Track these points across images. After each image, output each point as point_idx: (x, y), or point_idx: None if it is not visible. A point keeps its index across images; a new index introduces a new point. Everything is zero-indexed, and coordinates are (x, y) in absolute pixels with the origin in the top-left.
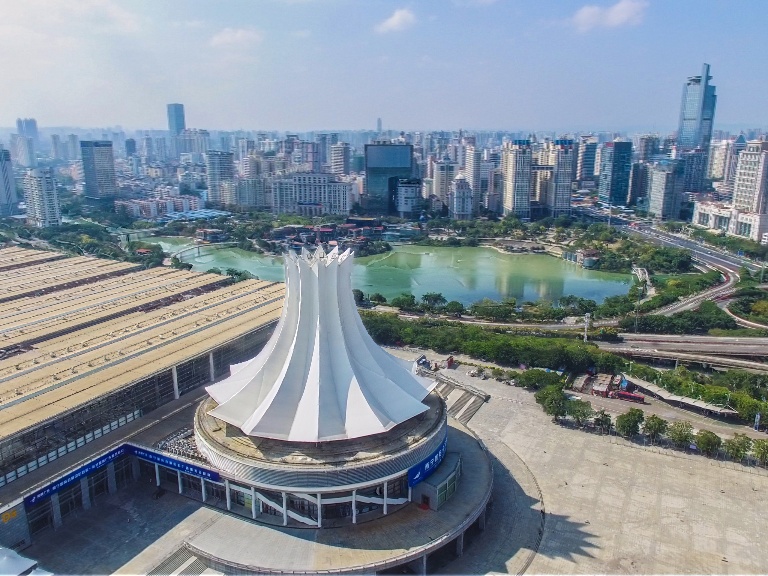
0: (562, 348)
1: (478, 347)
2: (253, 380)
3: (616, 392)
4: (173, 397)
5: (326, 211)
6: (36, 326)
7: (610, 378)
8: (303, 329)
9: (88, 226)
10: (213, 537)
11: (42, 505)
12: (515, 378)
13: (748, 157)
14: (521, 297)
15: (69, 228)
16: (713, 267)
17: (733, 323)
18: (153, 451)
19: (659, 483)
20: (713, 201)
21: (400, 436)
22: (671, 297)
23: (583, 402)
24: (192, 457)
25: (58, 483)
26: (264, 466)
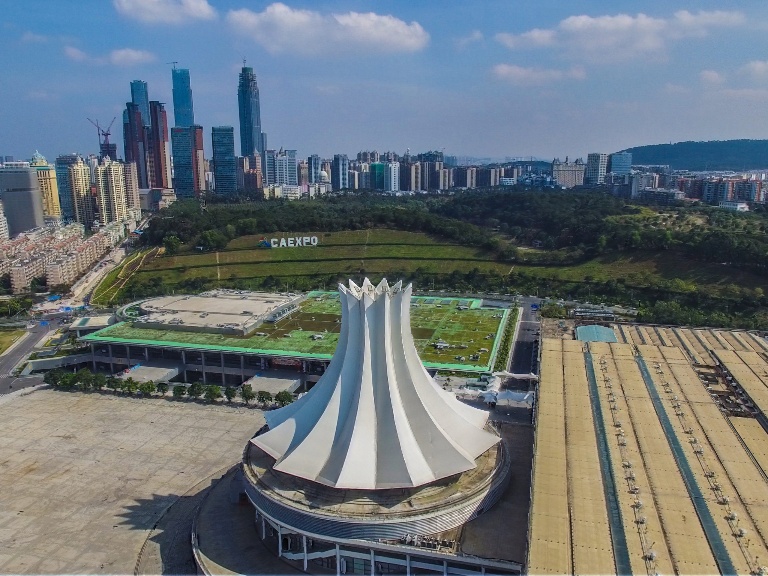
0: None
1: None
2: None
3: None
4: None
5: None
6: None
7: None
8: None
9: None
10: None
11: None
12: None
13: None
14: None
15: None
16: None
17: None
18: None
19: None
20: None
21: None
22: None
23: None
24: None
25: None
26: None
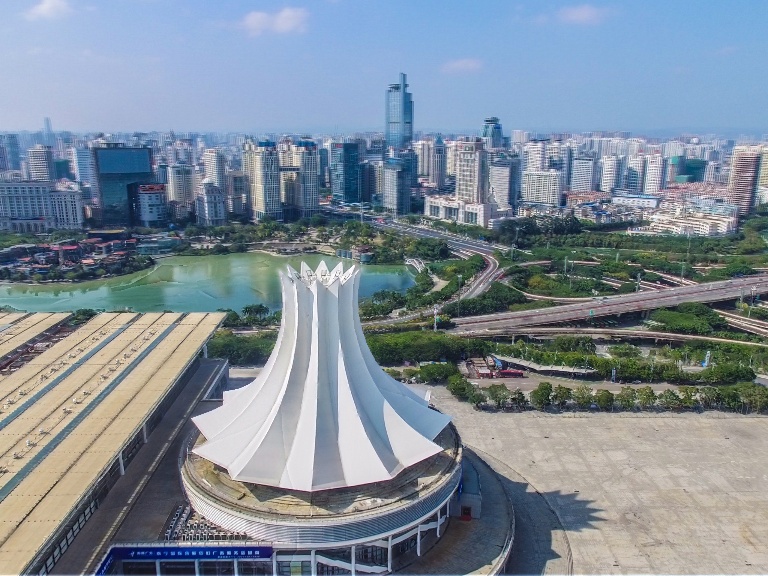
0: (437, 340)
1: None
2: (271, 428)
3: (498, 372)
4: (118, 474)
5: (51, 226)
6: None
7: (484, 360)
8: (322, 358)
9: None
10: None
11: None
12: (415, 375)
13: (465, 156)
14: None
15: None
16: (467, 252)
17: (524, 298)
18: (163, 546)
19: (595, 442)
20: (439, 195)
21: None
22: (463, 282)
23: (501, 385)
24: (224, 538)
25: None
26: (339, 522)
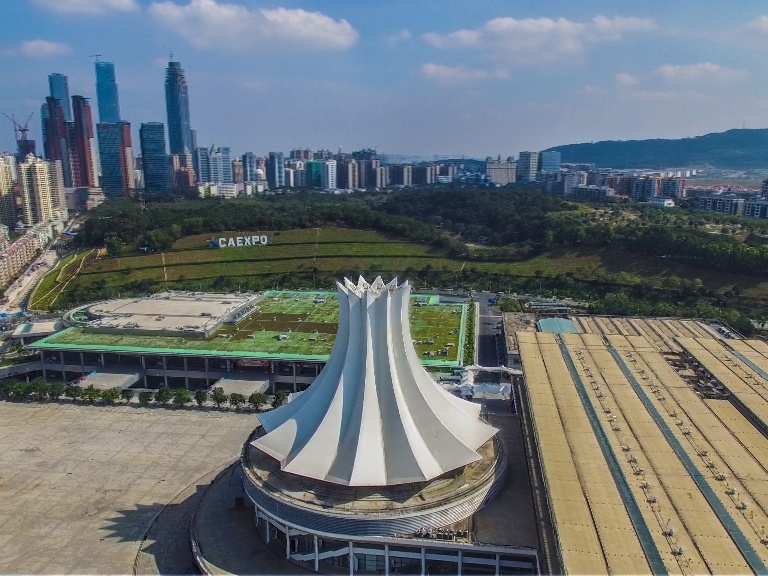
0: None
1: None
2: None
3: None
4: None
5: None
6: None
7: None
8: None
9: None
10: None
11: None
12: None
13: None
14: None
15: None
16: None
17: None
18: None
19: None
20: None
21: None
22: None
23: None
24: None
25: None
26: None
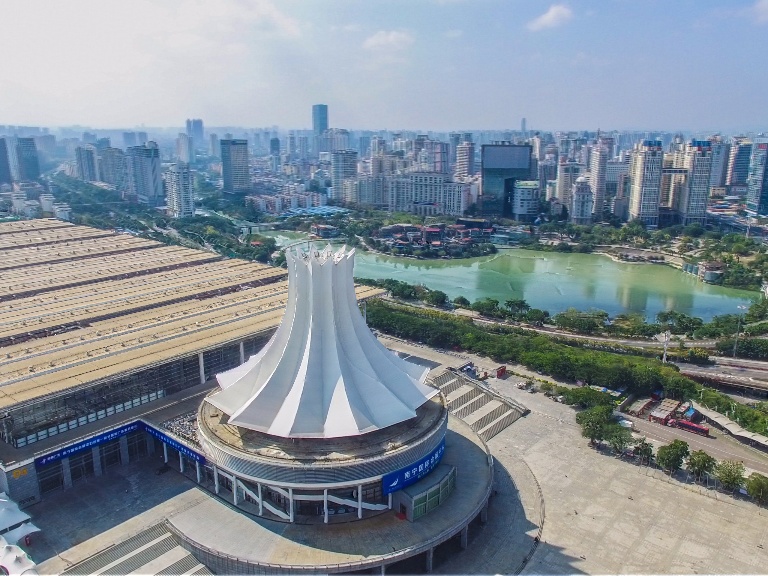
0: (626, 367)
1: (536, 358)
2: (251, 371)
3: (677, 420)
4: (199, 381)
5: (440, 211)
6: (101, 306)
7: (676, 404)
8: (298, 325)
9: (215, 218)
10: (192, 517)
11: (52, 467)
12: (563, 394)
13: None
14: (619, 309)
15: (199, 220)
16: None
17: None
18: (158, 430)
19: (685, 526)
20: None
21: (381, 441)
22: None
23: (622, 427)
24: (188, 439)
25: (69, 449)
26: (239, 455)
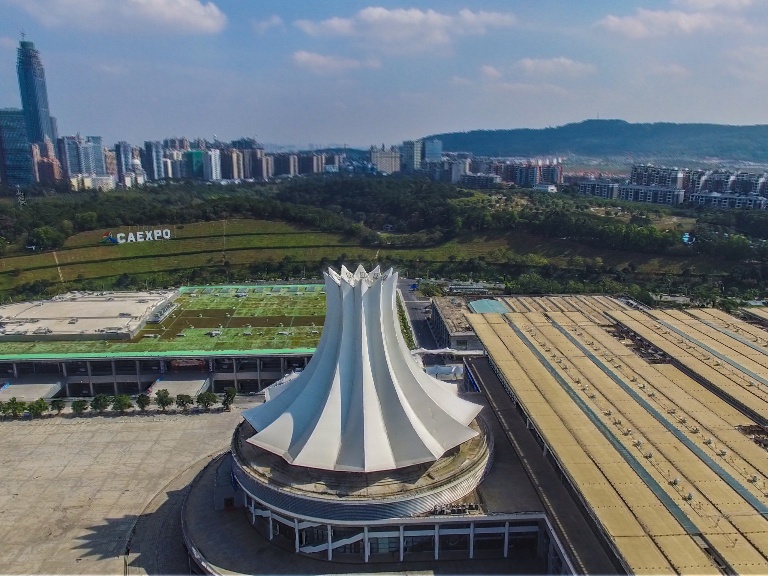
0: None
1: None
2: None
3: None
4: None
5: None
6: None
7: None
8: None
9: None
10: None
11: None
12: None
13: None
14: None
15: None
16: None
17: None
18: None
19: None
20: None
21: None
22: None
23: None
24: None
25: None
26: None
